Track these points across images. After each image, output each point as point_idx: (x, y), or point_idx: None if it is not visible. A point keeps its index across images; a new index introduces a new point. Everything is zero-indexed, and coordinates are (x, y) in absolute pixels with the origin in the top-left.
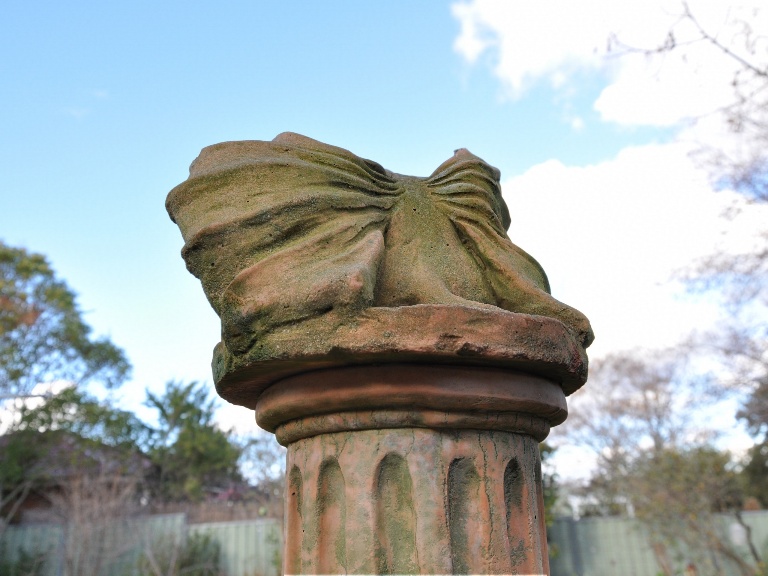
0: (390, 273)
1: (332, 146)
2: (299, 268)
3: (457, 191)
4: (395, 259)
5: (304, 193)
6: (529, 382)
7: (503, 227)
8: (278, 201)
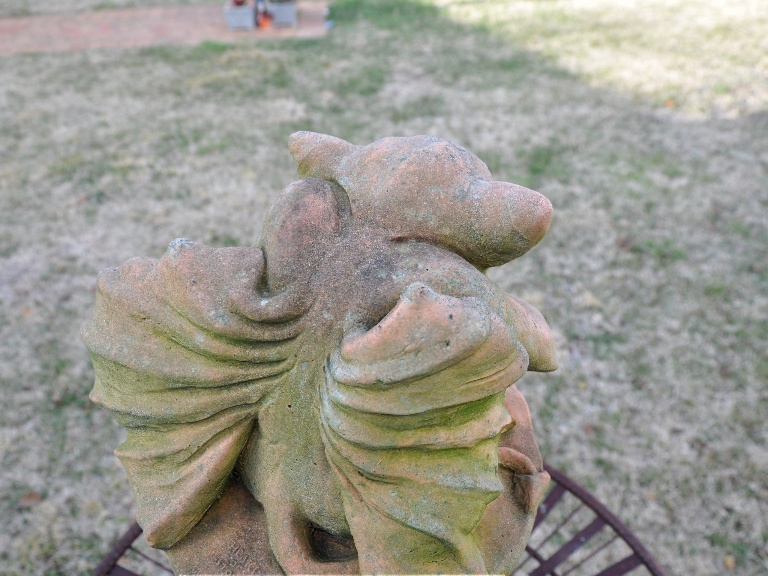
0: (252, 467)
1: (197, 305)
2: (141, 476)
3: None
4: (260, 455)
5: (140, 406)
6: None
7: None
8: (123, 405)
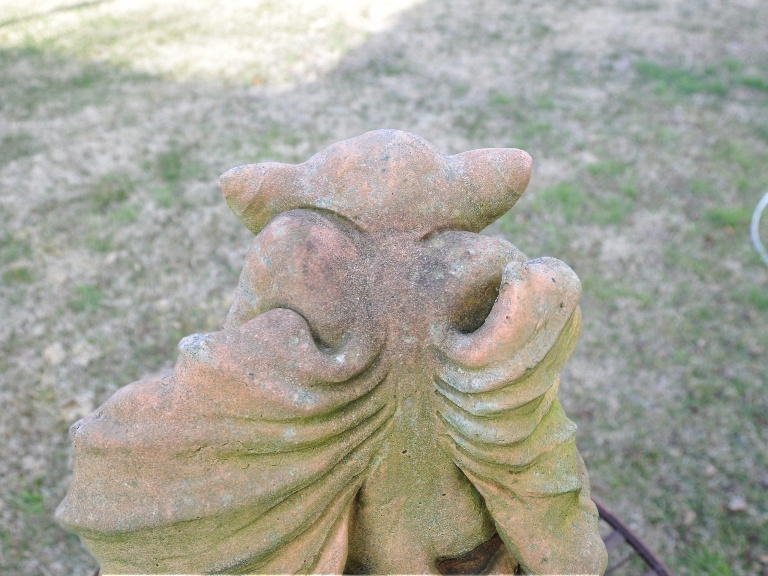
0: (359, 544)
1: (272, 398)
2: None
3: (471, 439)
4: (367, 526)
5: (228, 556)
6: None
7: None
8: (195, 570)
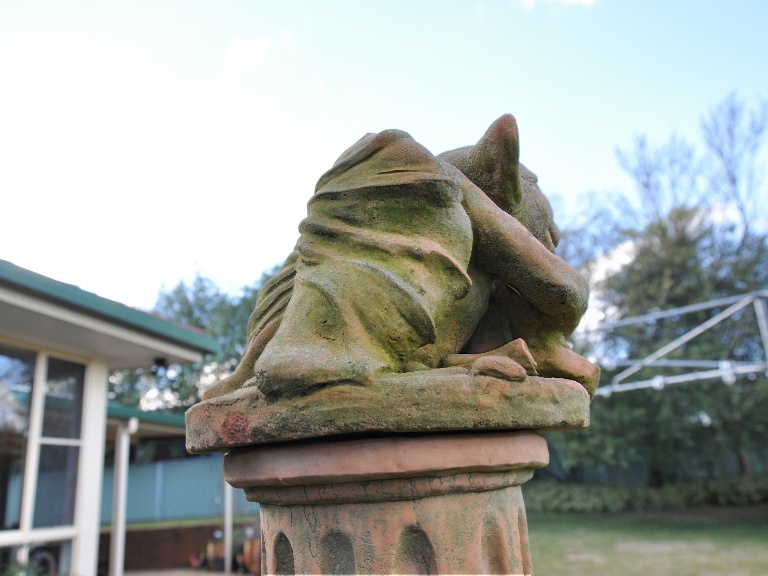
0: None
1: None
2: None
3: None
4: None
5: None
6: (239, 460)
7: (403, 198)
8: None
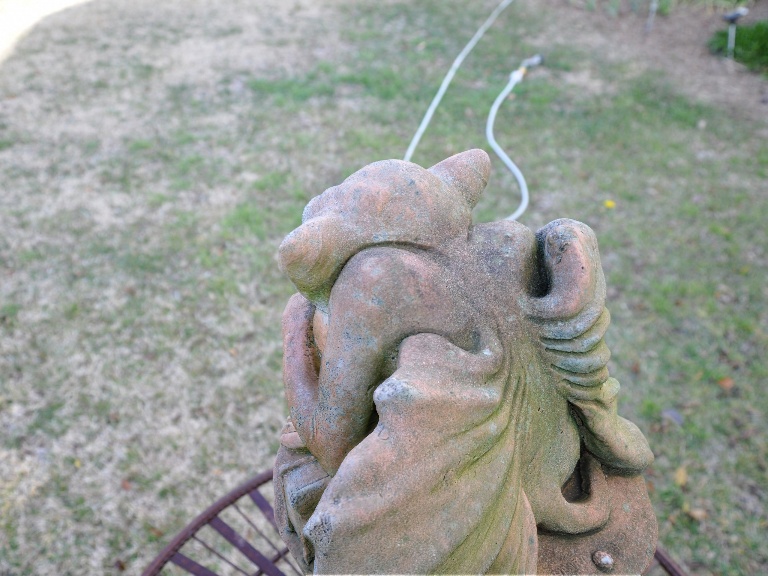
0: None
1: (476, 405)
2: None
3: None
4: None
5: (487, 560)
6: None
7: None
8: None
